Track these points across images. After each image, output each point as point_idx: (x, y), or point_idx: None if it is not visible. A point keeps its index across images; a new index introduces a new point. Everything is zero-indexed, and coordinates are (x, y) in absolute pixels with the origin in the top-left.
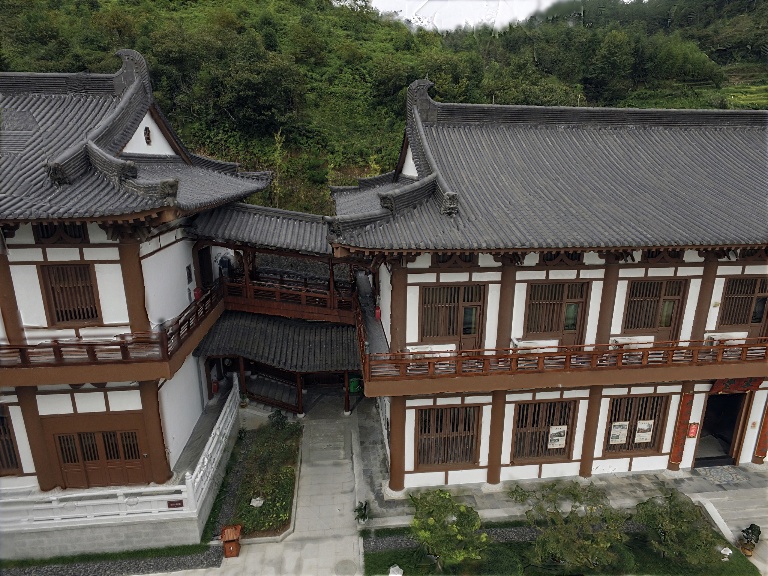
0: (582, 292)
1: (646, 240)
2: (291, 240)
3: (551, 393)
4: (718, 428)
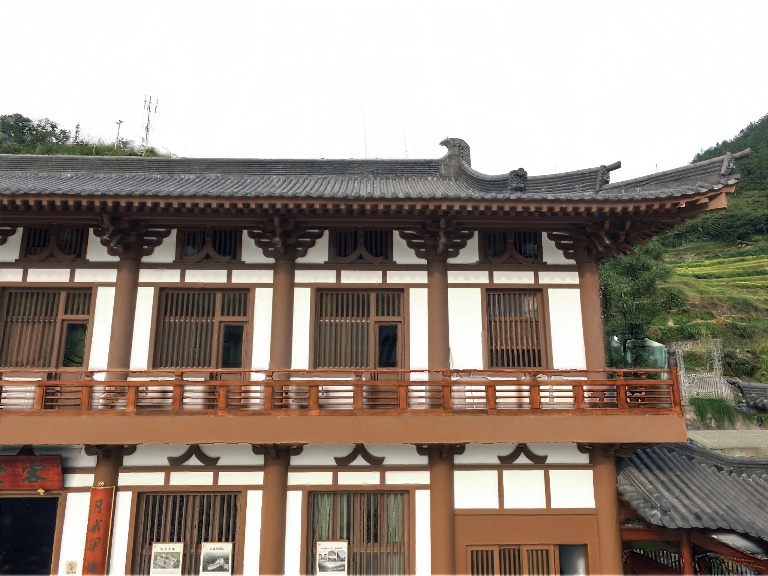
0: None
1: None
2: None
3: None
4: None
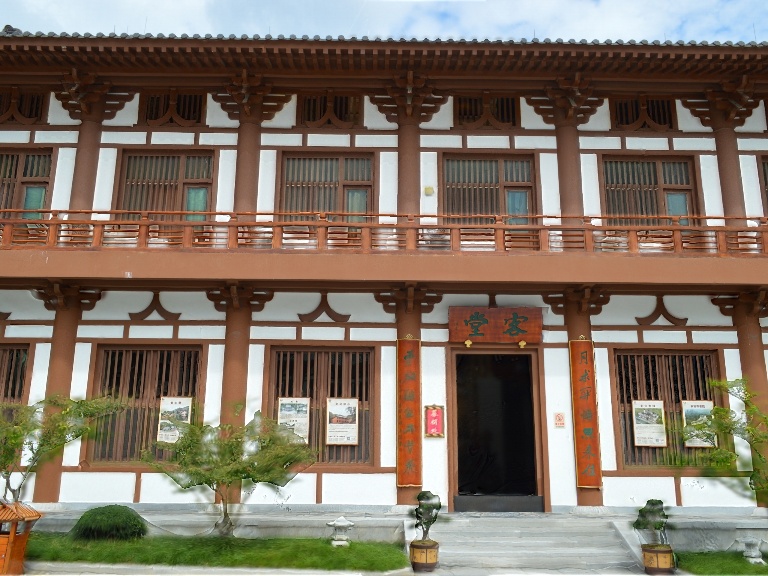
0: (210, 169)
1: None
2: None
3: (157, 328)
4: (508, 440)
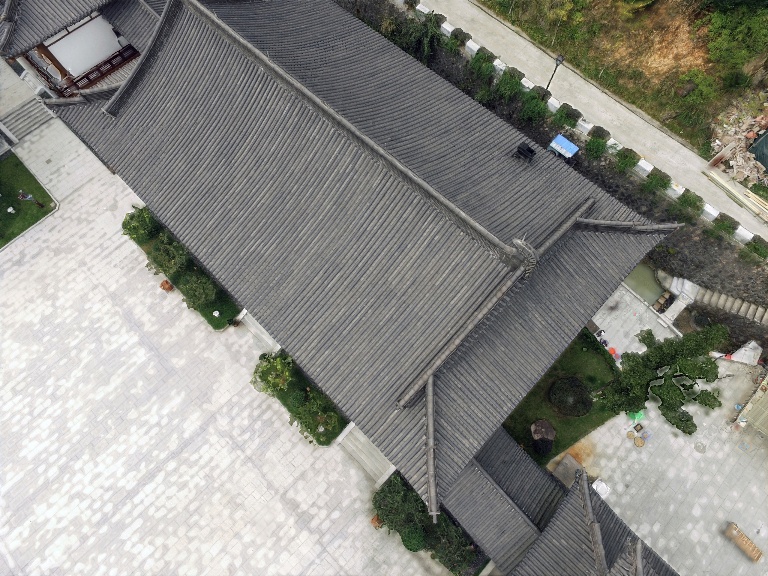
0: None
1: (149, 201)
2: (144, 44)
3: None
4: None
